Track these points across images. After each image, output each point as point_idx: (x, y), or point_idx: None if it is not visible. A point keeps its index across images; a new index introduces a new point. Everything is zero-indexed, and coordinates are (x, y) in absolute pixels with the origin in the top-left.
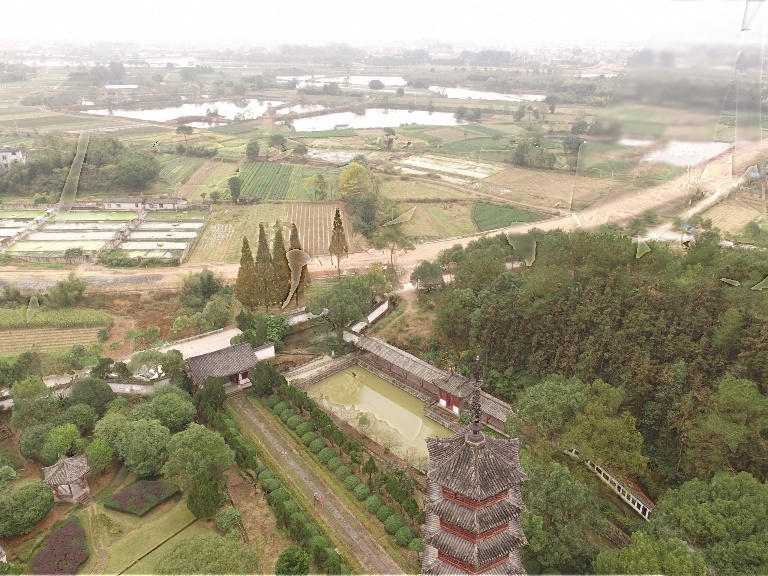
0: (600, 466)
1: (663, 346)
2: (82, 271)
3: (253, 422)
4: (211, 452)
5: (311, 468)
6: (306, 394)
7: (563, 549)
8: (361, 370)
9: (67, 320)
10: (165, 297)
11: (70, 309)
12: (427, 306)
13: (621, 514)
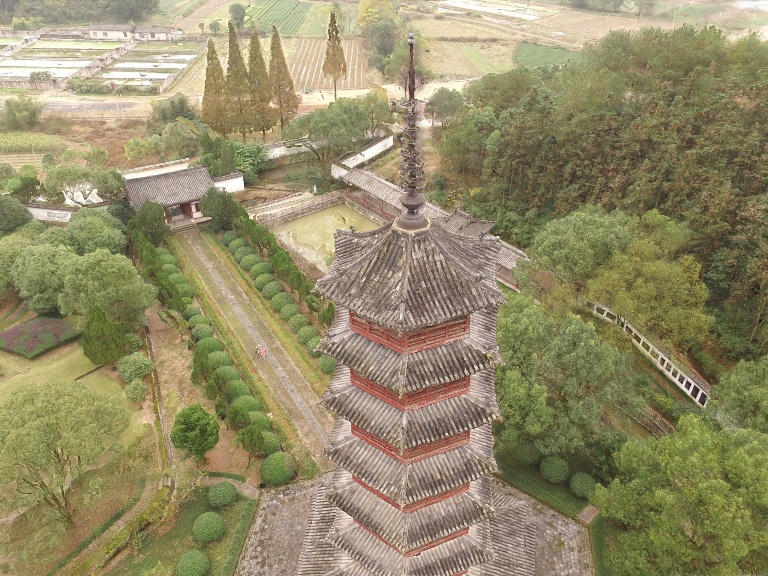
0: (640, 326)
1: (752, 171)
2: (46, 96)
3: (200, 260)
4: (115, 283)
5: (260, 316)
6: (267, 229)
7: (573, 433)
8: (348, 211)
9: (12, 143)
10: (132, 125)
11: (19, 132)
12: (441, 143)
13: (662, 394)
